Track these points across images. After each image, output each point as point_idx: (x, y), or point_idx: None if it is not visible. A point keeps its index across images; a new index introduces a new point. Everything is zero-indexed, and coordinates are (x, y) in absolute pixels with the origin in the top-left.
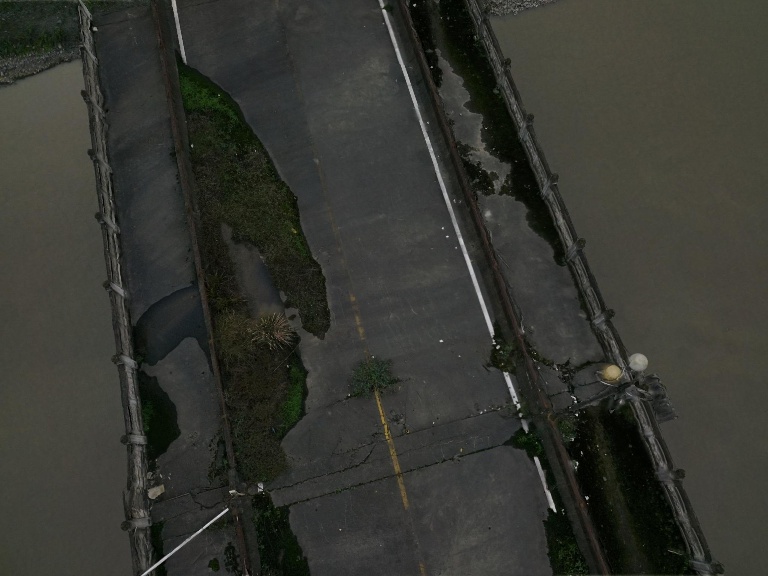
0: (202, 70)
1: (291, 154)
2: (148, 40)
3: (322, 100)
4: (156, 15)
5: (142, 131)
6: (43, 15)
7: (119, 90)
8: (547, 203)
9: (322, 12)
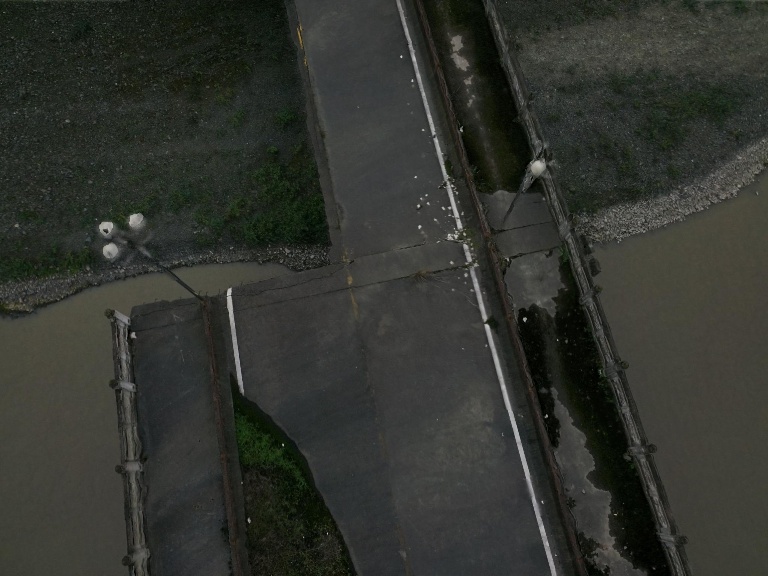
0: (263, 405)
1: (371, 541)
2: (197, 356)
3: (410, 460)
4: (209, 332)
5: (188, 492)
6: (70, 229)
7: (161, 428)
8: None
9: (411, 325)
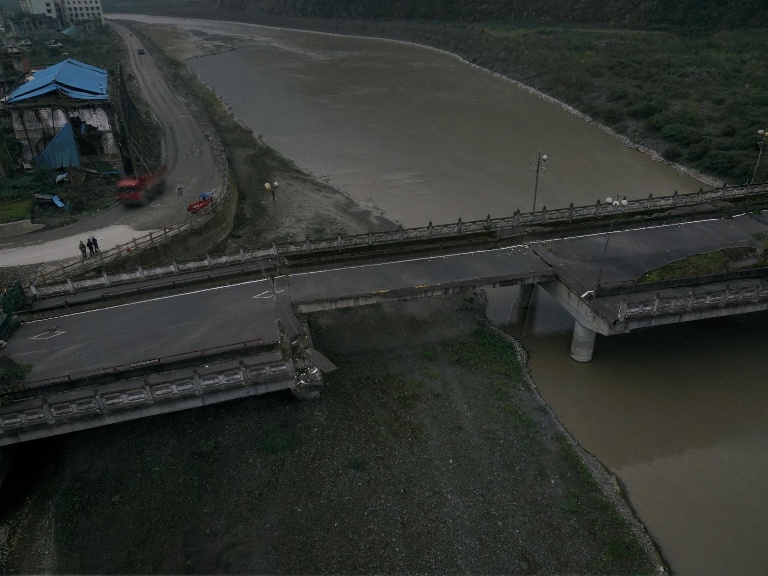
0: None
1: None
2: None
3: (631, 250)
4: None
5: None
6: None
7: None
8: (651, 209)
9: None
